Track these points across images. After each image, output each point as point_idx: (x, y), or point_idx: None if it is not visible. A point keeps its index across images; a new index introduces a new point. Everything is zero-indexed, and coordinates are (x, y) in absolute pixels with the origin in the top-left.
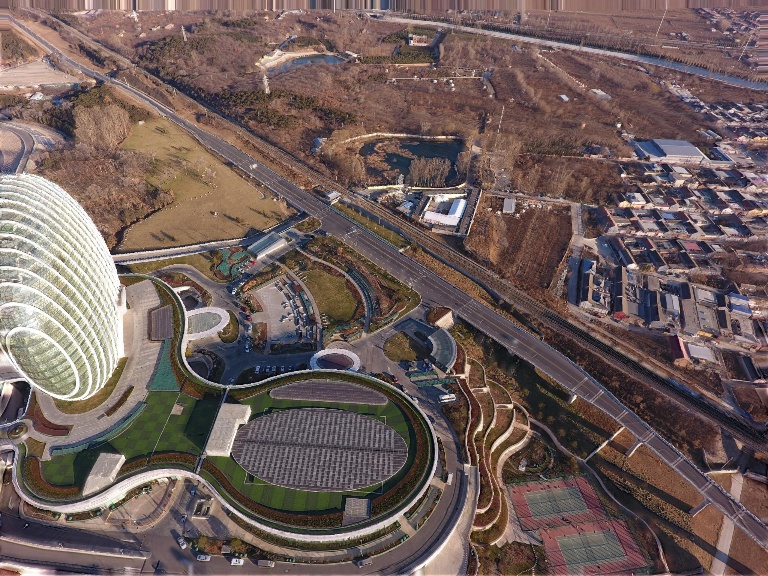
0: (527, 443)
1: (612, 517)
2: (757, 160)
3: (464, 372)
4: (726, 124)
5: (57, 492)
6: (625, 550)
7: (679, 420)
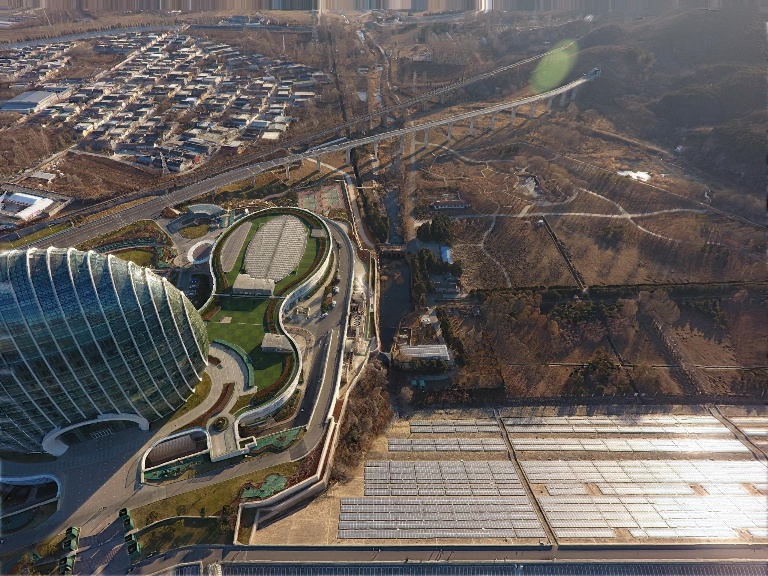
0: (276, 205)
1: (319, 189)
2: (72, 83)
3: (227, 207)
4: (13, 76)
5: (288, 368)
6: (334, 189)
7: (276, 157)
